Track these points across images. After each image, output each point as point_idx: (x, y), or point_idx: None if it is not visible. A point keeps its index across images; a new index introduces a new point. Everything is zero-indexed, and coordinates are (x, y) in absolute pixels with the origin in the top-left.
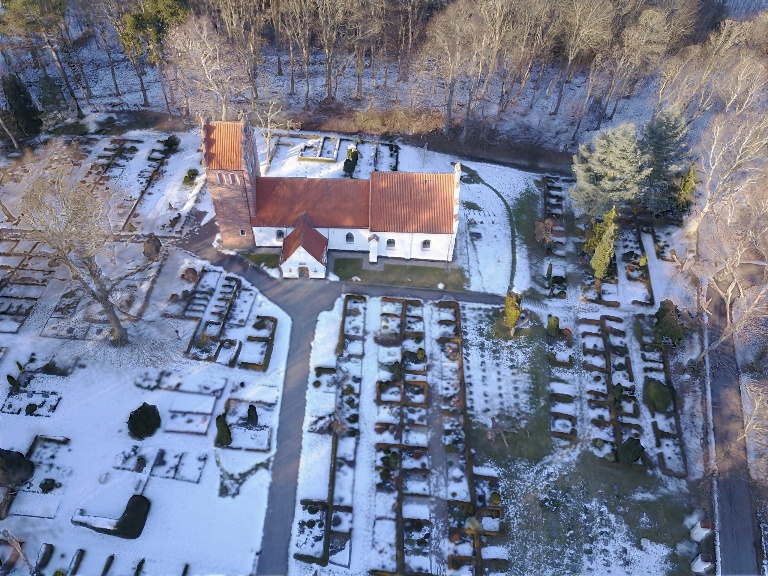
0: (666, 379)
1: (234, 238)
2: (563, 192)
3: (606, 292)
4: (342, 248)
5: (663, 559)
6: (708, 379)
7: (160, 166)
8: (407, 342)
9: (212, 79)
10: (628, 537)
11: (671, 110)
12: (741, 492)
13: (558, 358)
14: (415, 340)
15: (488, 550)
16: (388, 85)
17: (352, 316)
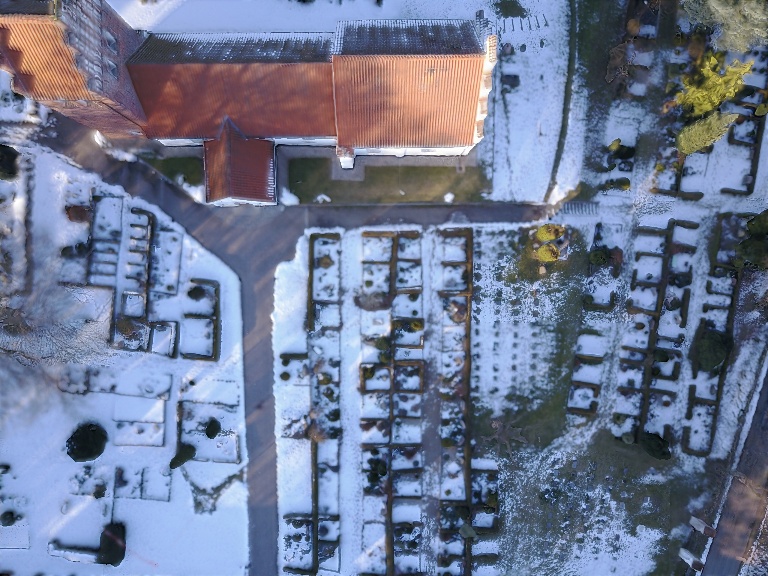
0: (727, 325)
1: (125, 136)
2: None
3: (689, 171)
4: (298, 144)
5: (654, 544)
6: None
7: None
8: (398, 299)
9: None
10: (624, 525)
11: None
12: (762, 470)
13: (596, 298)
14: (409, 296)
15: (479, 546)
16: None
17: (322, 268)
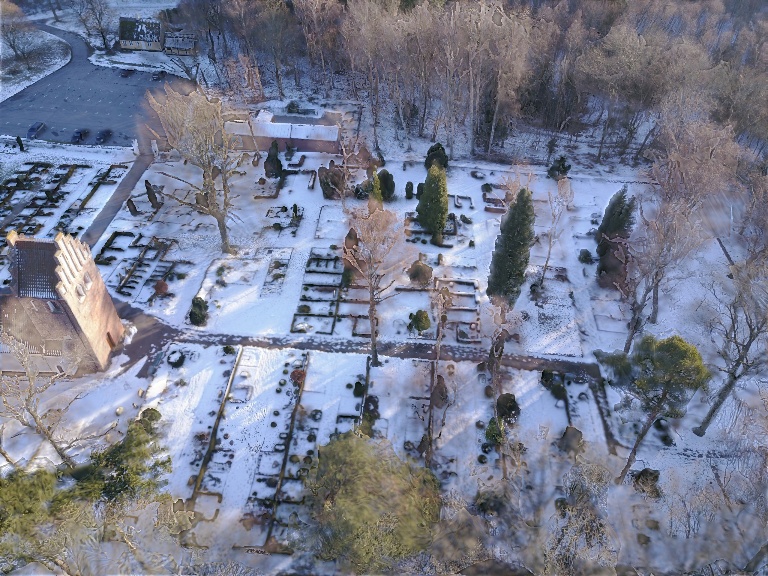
0: None
1: None
2: None
3: None
4: None
5: None
6: None
7: (200, 473)
8: None
9: None
10: None
11: None
12: None
13: None
14: None
15: None
16: None
17: None
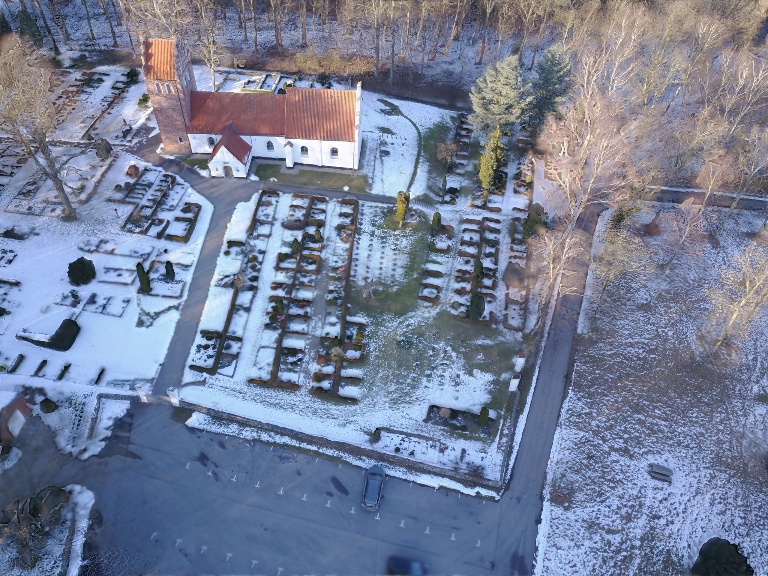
0: (525, 263)
1: (174, 145)
2: (474, 126)
3: (492, 201)
4: (265, 156)
5: (488, 383)
6: (562, 266)
7: (121, 93)
8: (309, 228)
9: (160, 11)
10: (463, 368)
11: (556, 48)
12: (566, 342)
13: (438, 246)
14: (316, 226)
15: (347, 371)
16: (333, 36)
17: (265, 206)
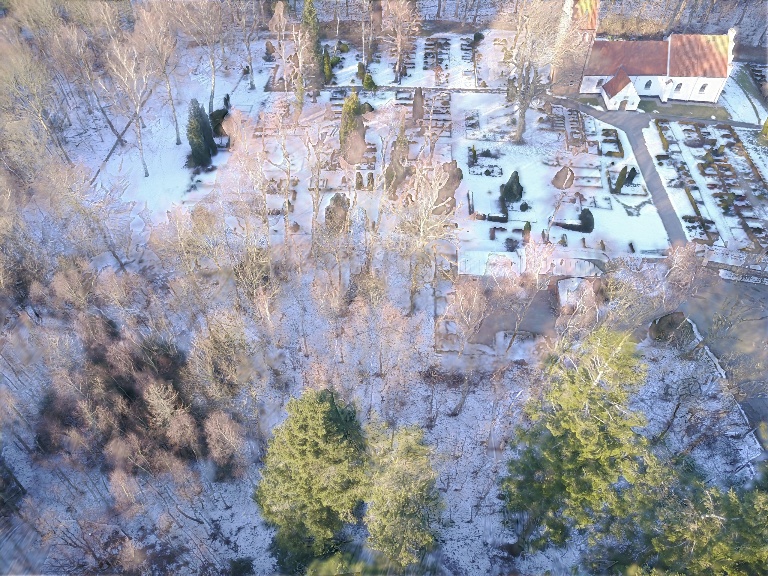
0: None
1: (564, 88)
2: (763, 73)
3: None
4: (640, 94)
5: None
6: None
7: (475, 53)
8: (705, 146)
9: None
10: None
11: None
12: None
13: None
14: (710, 145)
15: None
16: (607, 5)
17: (664, 131)
